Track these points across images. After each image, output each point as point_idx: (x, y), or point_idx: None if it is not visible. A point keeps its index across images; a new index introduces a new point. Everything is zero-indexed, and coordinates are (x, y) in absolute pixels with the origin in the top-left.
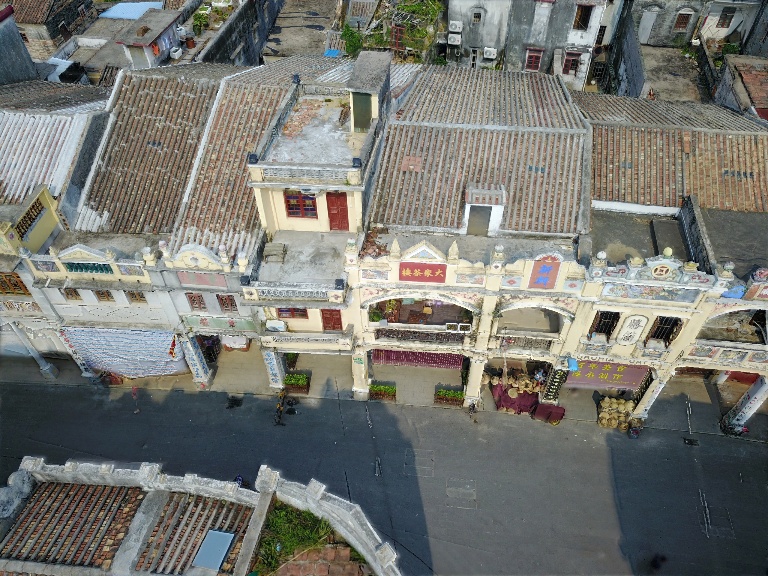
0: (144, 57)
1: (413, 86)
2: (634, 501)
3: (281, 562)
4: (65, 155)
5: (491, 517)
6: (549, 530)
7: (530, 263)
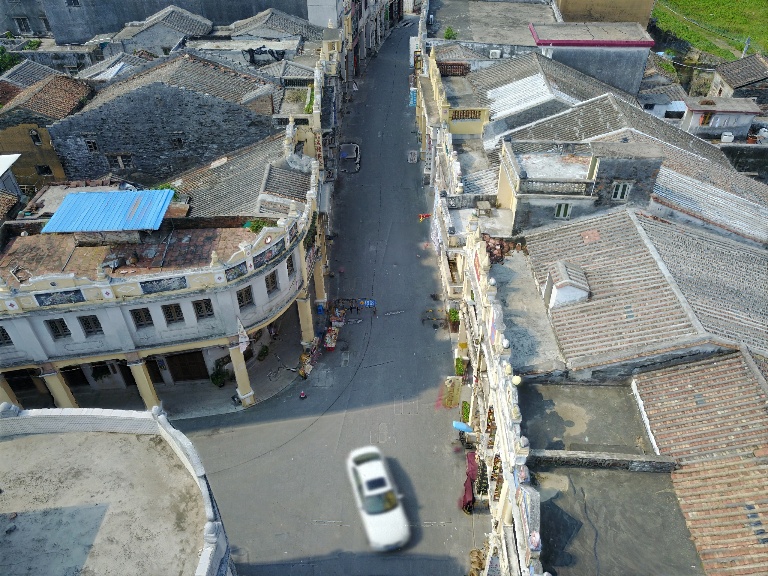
0: (690, 120)
1: (760, 249)
2: (391, 573)
3: (257, 233)
4: (520, 106)
5: (365, 453)
6: (357, 495)
7: (492, 310)
